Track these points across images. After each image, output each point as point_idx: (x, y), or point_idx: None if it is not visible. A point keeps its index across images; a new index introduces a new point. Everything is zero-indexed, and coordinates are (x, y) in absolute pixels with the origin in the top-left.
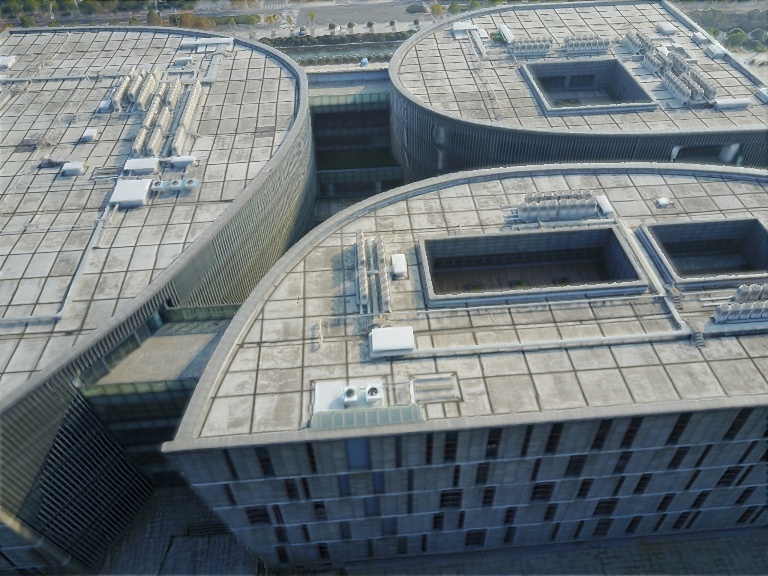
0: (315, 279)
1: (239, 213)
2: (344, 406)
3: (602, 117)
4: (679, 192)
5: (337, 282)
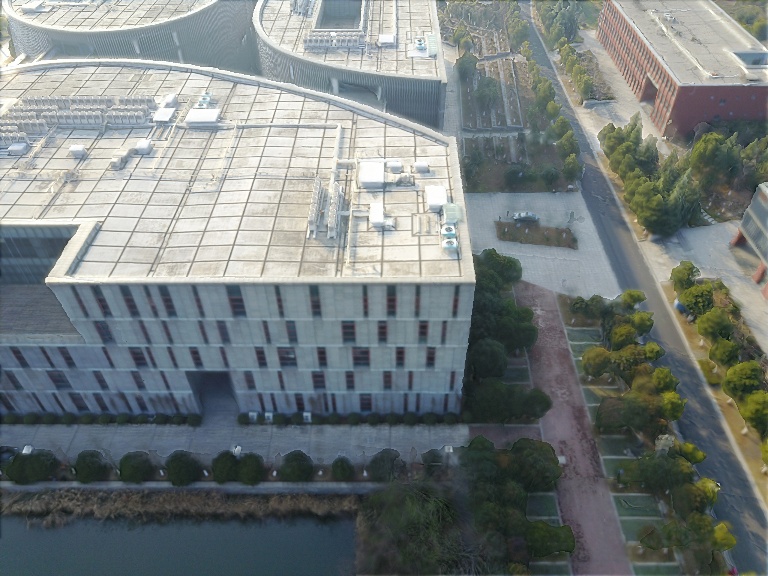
0: (333, 58)
1: None
2: (424, 50)
3: None
4: None
5: None
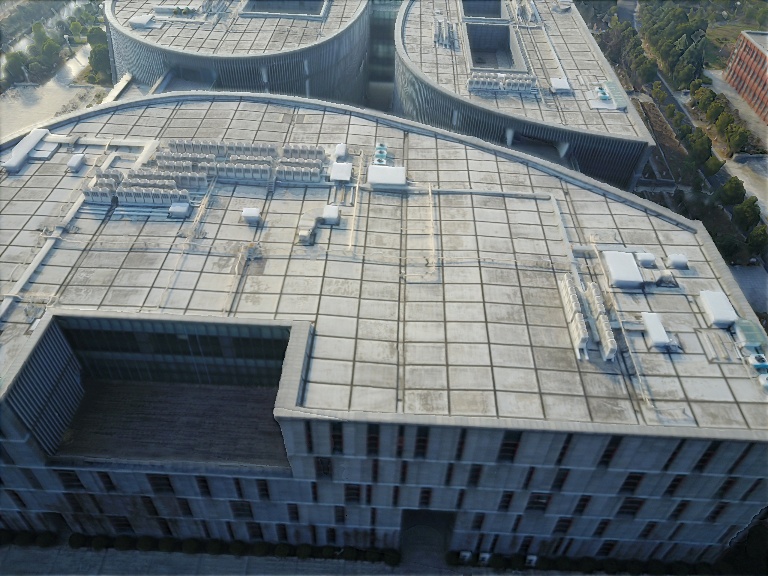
0: (506, 104)
1: None
2: (608, 100)
3: (335, 7)
4: (428, 7)
5: (509, 98)
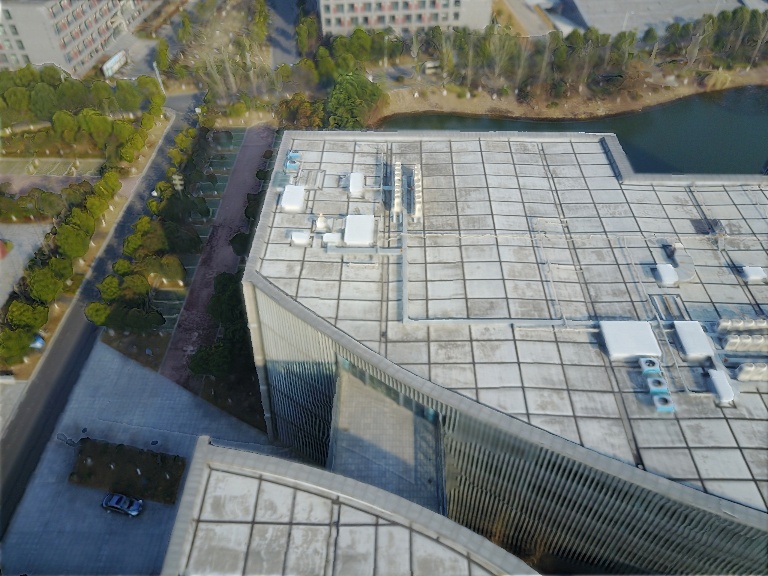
0: None
1: (614, 477)
2: None
3: None
4: None
5: None
